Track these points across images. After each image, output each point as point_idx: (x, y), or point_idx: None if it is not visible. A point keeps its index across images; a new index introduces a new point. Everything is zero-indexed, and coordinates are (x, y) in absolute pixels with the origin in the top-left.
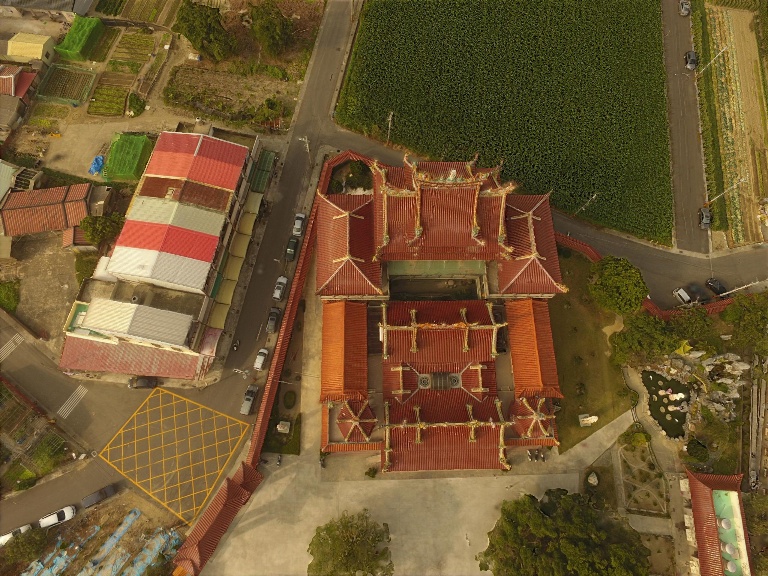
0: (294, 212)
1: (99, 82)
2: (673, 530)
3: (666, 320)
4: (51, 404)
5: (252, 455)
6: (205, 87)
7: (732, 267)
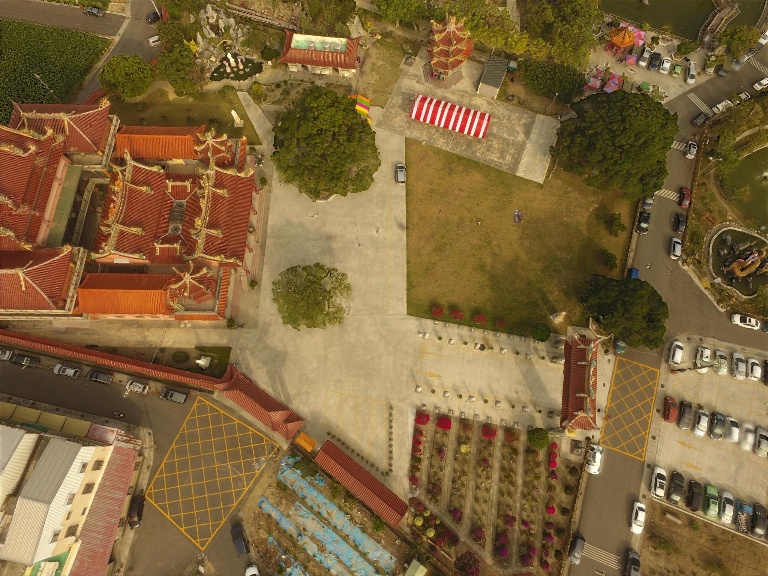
0: None
1: None
2: (323, 82)
3: None
4: None
5: None
6: None
7: (141, 4)
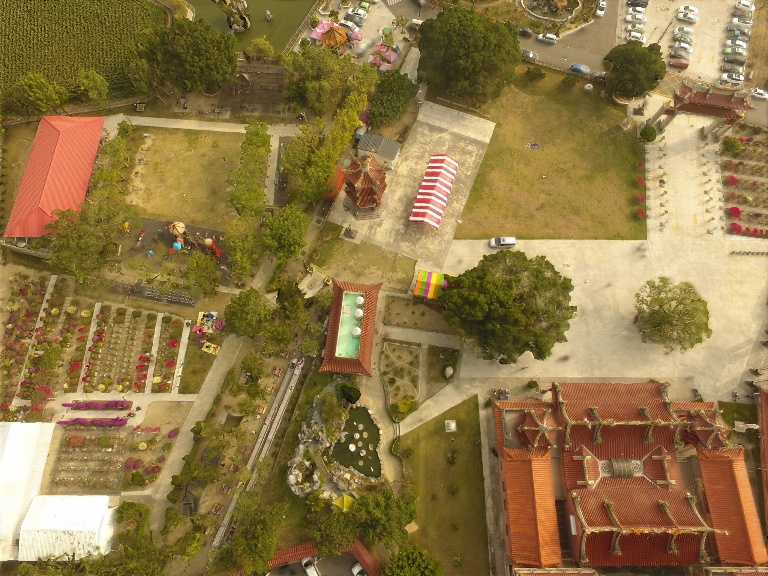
0: None
1: None
2: (381, 329)
3: None
4: None
5: None
6: None
7: None
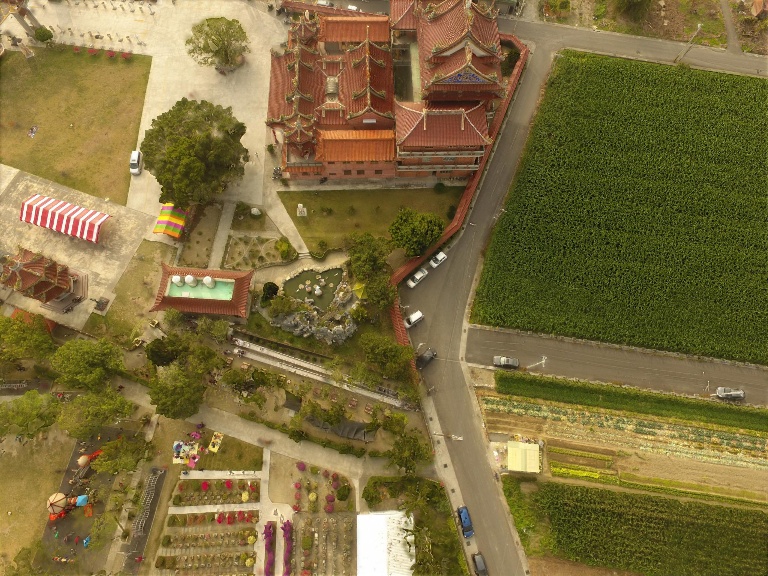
0: None
1: None
2: None
3: None
4: None
5: (291, 2)
6: None
7: (452, 384)
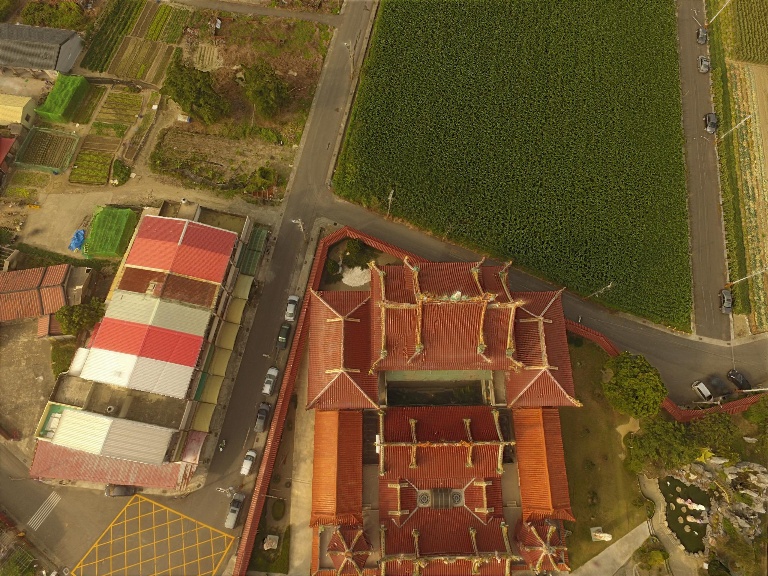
0: (287, 293)
1: (82, 147)
2: None
3: (685, 421)
4: (21, 514)
5: None
6: (194, 153)
7: (755, 356)
